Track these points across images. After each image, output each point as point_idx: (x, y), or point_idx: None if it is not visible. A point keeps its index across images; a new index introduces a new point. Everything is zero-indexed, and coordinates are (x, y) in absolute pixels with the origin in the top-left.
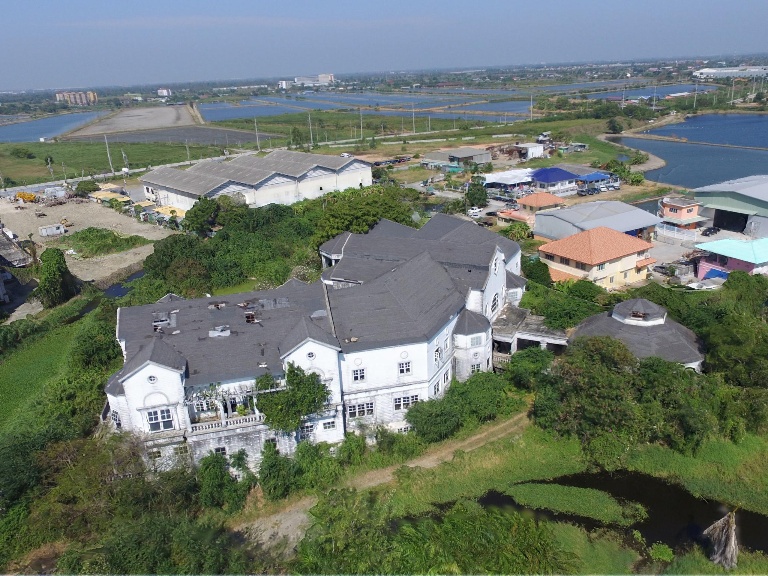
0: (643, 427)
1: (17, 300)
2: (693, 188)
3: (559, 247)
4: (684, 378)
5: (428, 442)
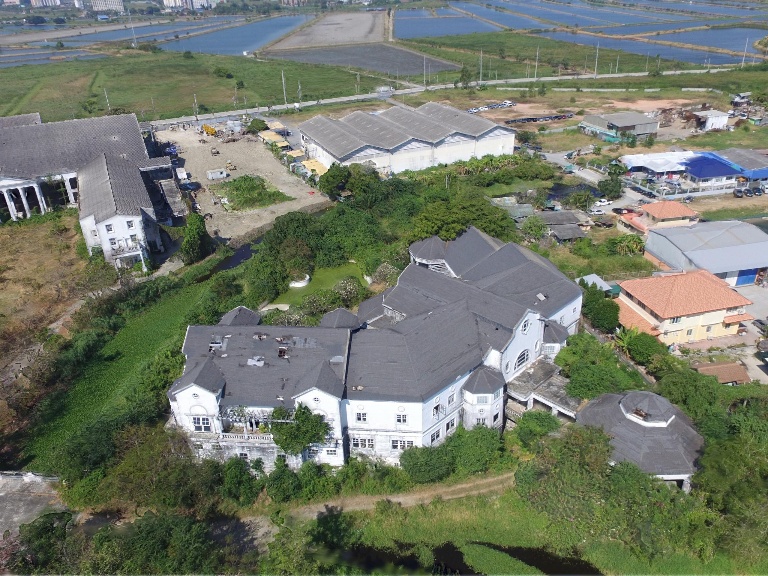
0: None
1: (170, 250)
2: None
3: (639, 288)
4: (661, 490)
5: (415, 482)
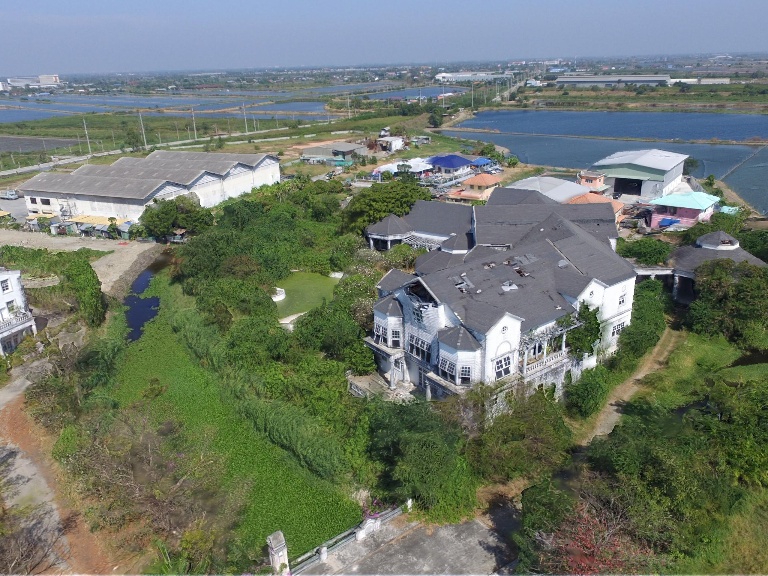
0: (767, 317)
1: None
2: (559, 166)
3: None
4: None
5: (639, 357)
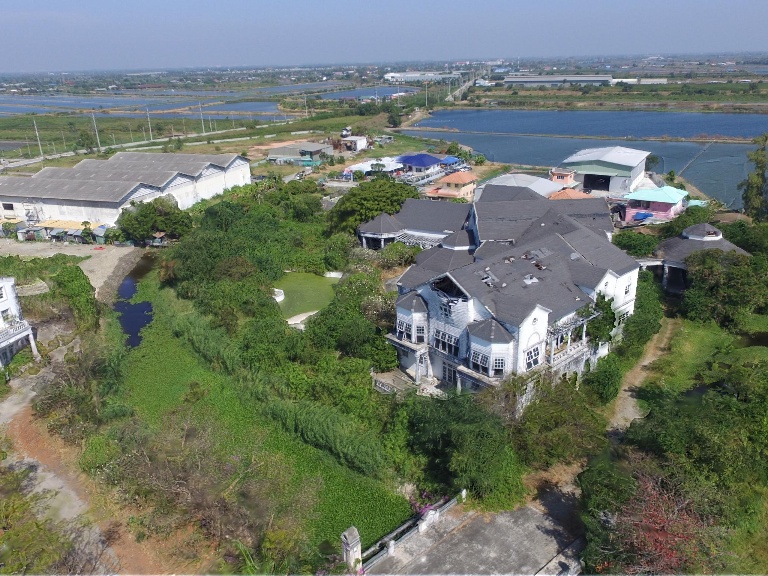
0: None
1: None
2: (525, 164)
3: None
4: None
5: None
